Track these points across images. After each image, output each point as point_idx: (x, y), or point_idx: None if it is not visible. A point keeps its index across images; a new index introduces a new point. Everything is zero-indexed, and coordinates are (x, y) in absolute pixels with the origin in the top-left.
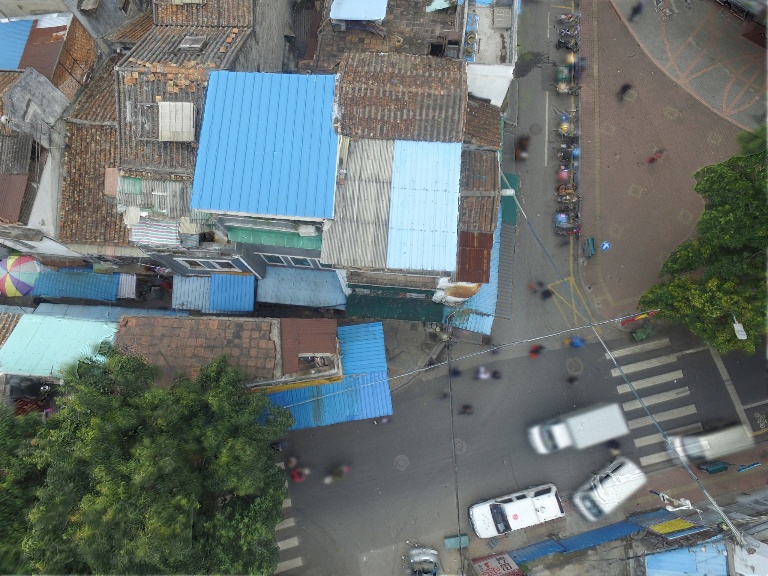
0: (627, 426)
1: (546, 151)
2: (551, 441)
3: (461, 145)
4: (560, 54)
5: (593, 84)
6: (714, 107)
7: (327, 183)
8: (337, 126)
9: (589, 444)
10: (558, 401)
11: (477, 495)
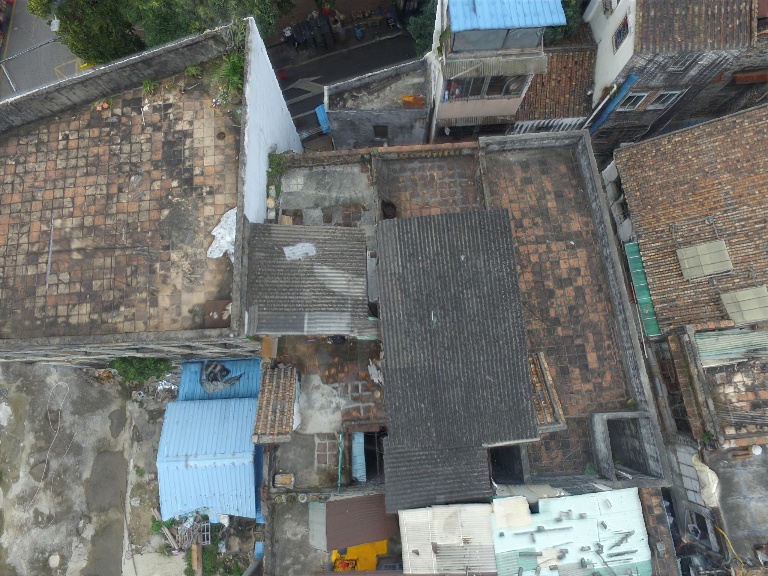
0: None
1: None
2: None
3: None
4: None
5: None
6: None
7: None
8: None
9: None
10: None
11: None
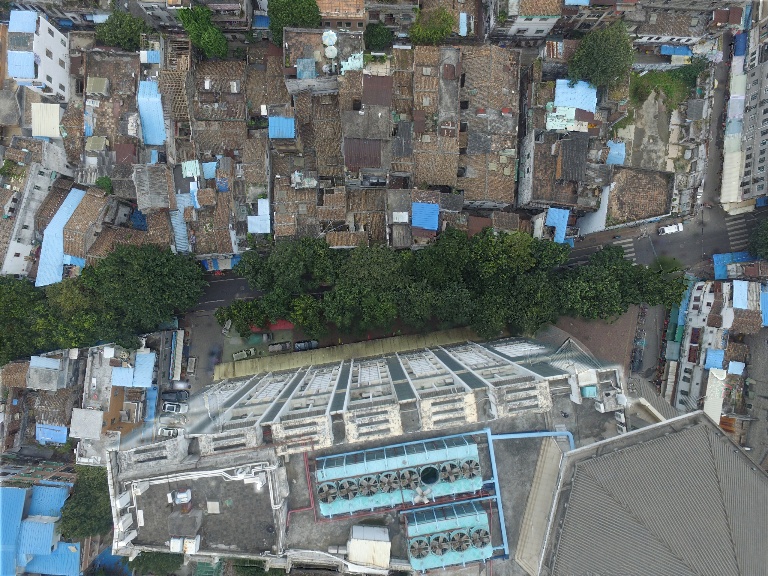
0: (635, 249)
1: (645, 338)
2: (656, 246)
3: (733, 307)
4: (635, 377)
5: (626, 363)
6: (588, 351)
7: (762, 300)
8: (761, 312)
9: (646, 245)
10: (653, 257)
11: (678, 233)
